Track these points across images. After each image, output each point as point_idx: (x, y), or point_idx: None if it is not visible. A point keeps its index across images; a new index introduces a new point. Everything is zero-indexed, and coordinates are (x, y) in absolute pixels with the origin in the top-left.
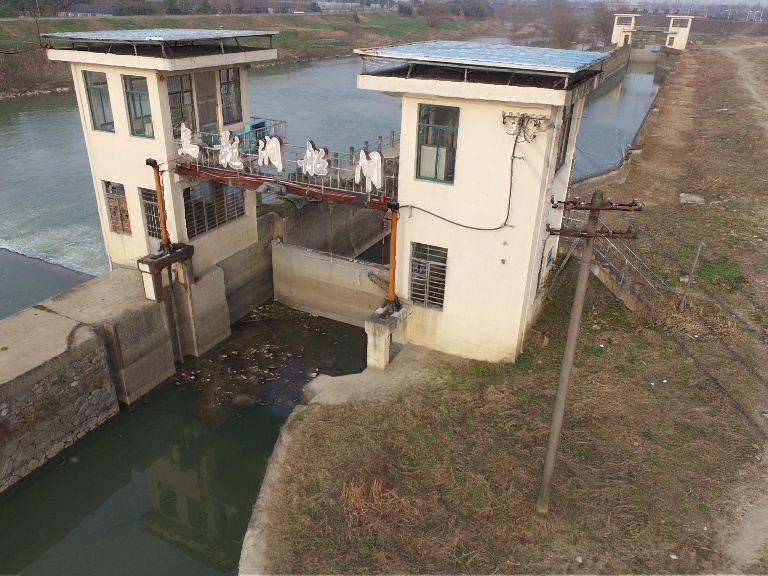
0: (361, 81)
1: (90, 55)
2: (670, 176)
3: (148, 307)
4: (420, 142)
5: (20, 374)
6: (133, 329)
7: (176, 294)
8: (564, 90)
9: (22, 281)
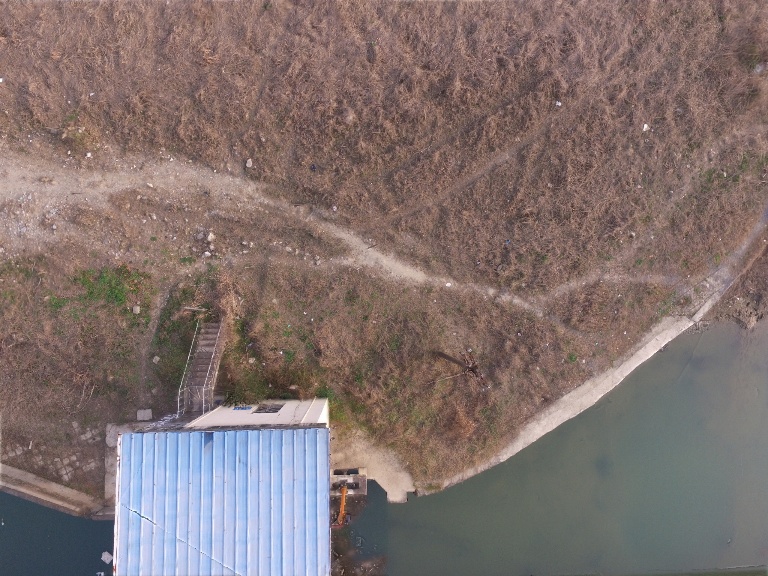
0: None
1: None
2: None
3: None
4: None
5: None
6: None
7: None
8: None
9: None
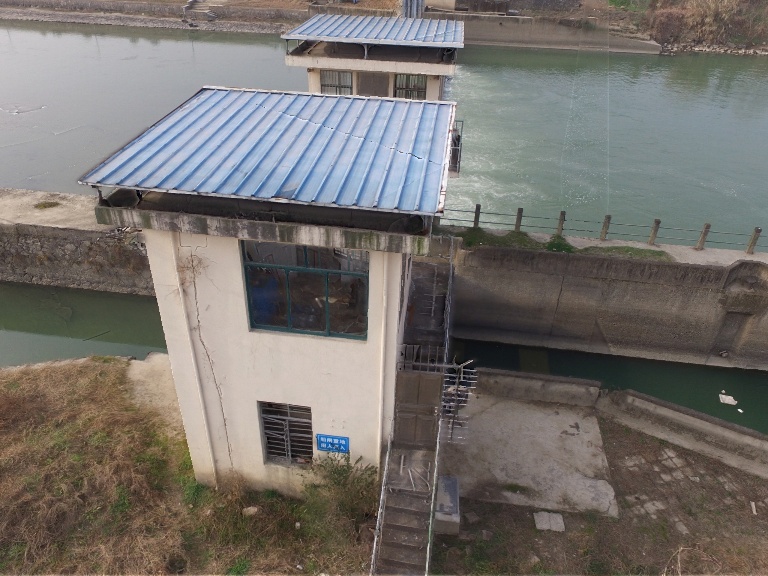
0: None
1: None
2: None
3: None
4: None
5: None
6: None
7: None
8: None
9: None
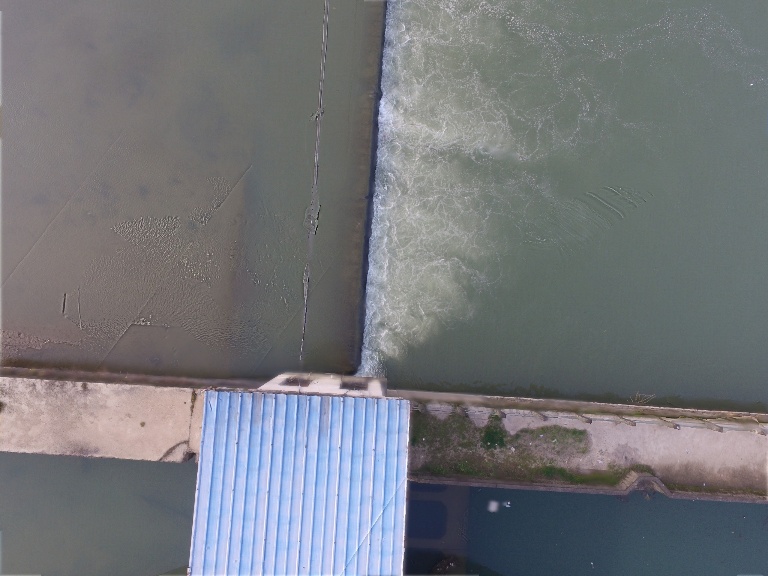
0: None
1: None
2: None
3: None
4: None
5: None
6: None
7: None
8: None
9: (331, 216)
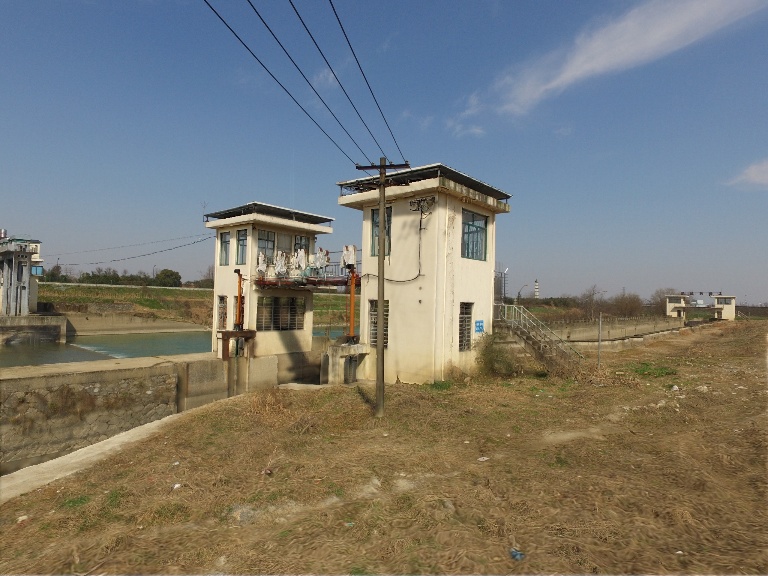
0: (340, 200)
1: (223, 220)
2: (662, 352)
3: (215, 361)
4: (375, 235)
5: (115, 369)
6: (200, 371)
7: (240, 364)
8: (438, 177)
9: None
